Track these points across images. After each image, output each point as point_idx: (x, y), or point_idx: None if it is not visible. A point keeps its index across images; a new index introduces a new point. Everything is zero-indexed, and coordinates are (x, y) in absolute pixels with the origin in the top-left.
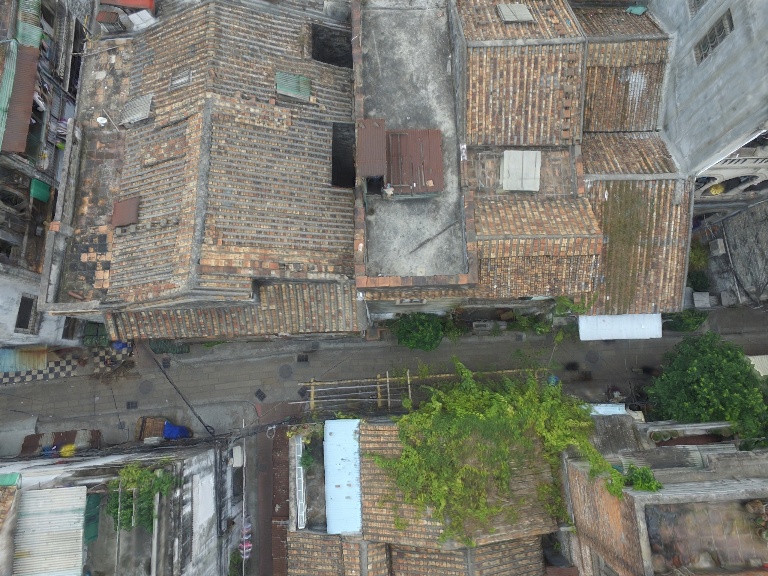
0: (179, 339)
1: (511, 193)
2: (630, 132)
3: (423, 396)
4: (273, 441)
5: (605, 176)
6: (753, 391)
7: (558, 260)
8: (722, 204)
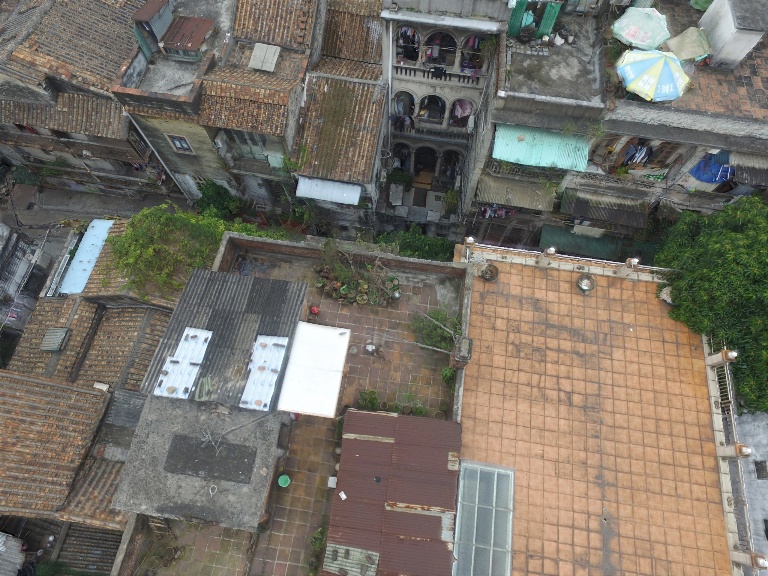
0: (27, 162)
1: (254, 71)
2: (370, 63)
3: None
4: None
5: (326, 75)
6: (414, 254)
7: (258, 105)
8: (449, 139)
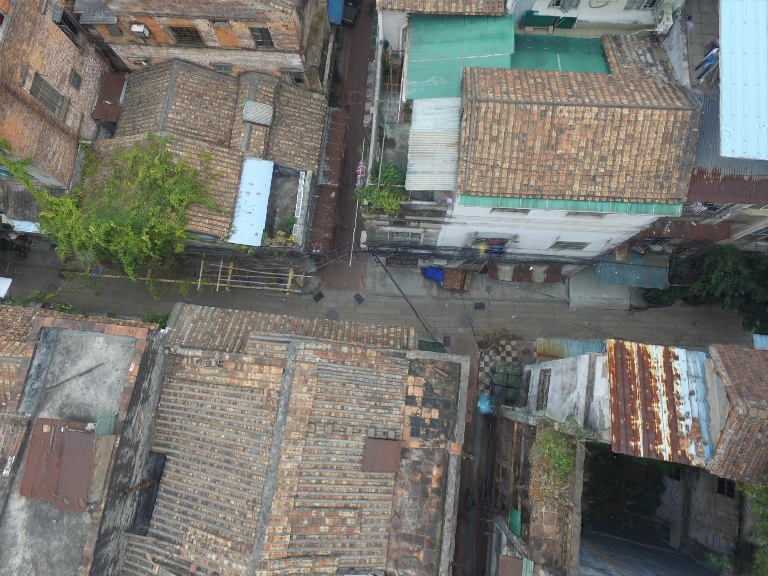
0: None
1: None
2: None
3: (192, 266)
4: (330, 247)
5: None
6: None
7: None
8: None
